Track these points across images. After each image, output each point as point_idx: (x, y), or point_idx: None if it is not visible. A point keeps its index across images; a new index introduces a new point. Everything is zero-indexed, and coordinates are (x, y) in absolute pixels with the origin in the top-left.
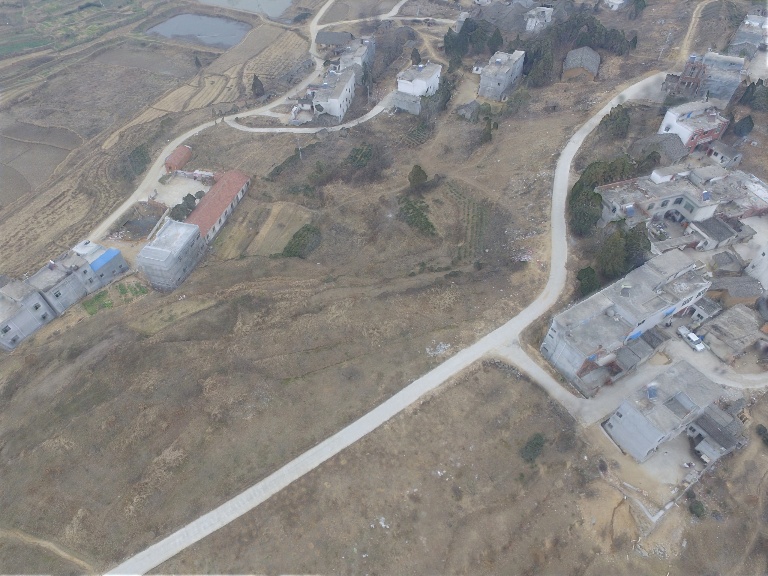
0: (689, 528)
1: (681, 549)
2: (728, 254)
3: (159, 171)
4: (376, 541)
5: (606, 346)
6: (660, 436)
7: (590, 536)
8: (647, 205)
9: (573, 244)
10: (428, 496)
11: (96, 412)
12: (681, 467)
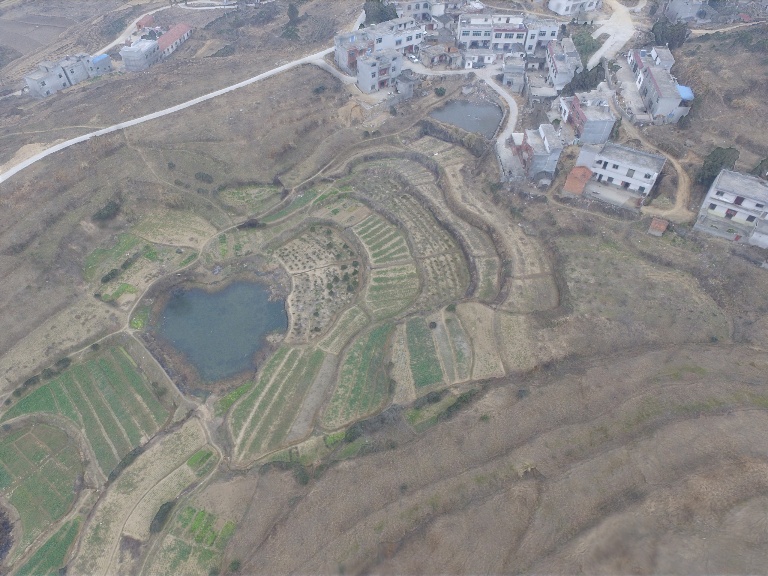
0: (388, 119)
1: None
2: (444, 27)
3: (132, 30)
4: (237, 114)
5: None
6: (369, 70)
7: (341, 121)
8: (406, 6)
9: (365, 26)
10: (264, 103)
11: (101, 97)
12: (387, 95)
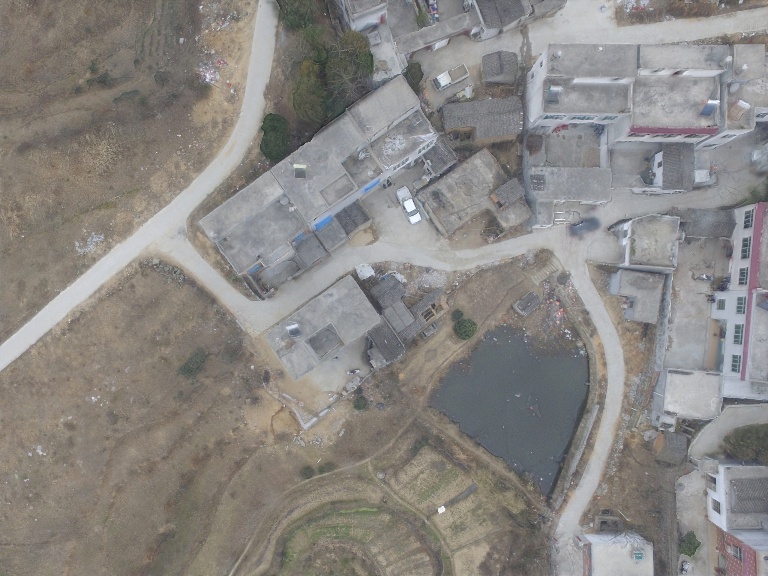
0: (350, 419)
1: (337, 438)
2: (501, 57)
3: None
4: (34, 468)
5: (268, 253)
6: None
7: (254, 434)
8: None
9: (283, 44)
10: (82, 423)
11: None
12: (346, 374)
